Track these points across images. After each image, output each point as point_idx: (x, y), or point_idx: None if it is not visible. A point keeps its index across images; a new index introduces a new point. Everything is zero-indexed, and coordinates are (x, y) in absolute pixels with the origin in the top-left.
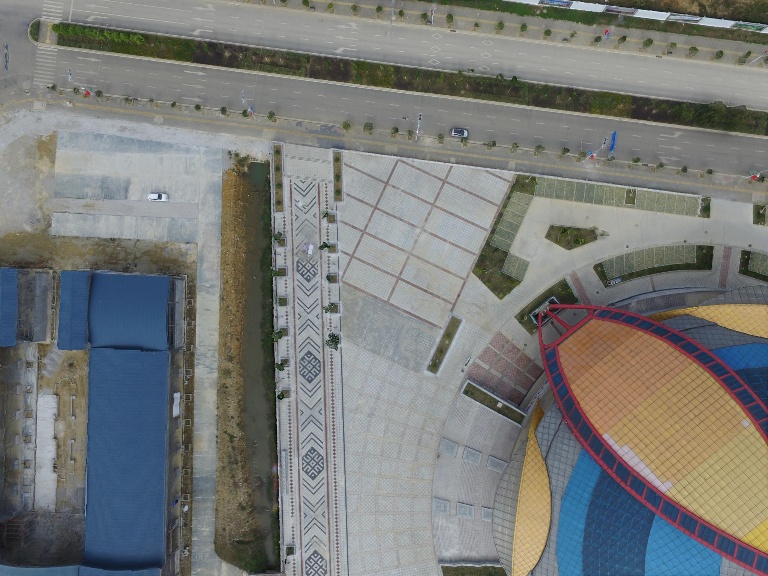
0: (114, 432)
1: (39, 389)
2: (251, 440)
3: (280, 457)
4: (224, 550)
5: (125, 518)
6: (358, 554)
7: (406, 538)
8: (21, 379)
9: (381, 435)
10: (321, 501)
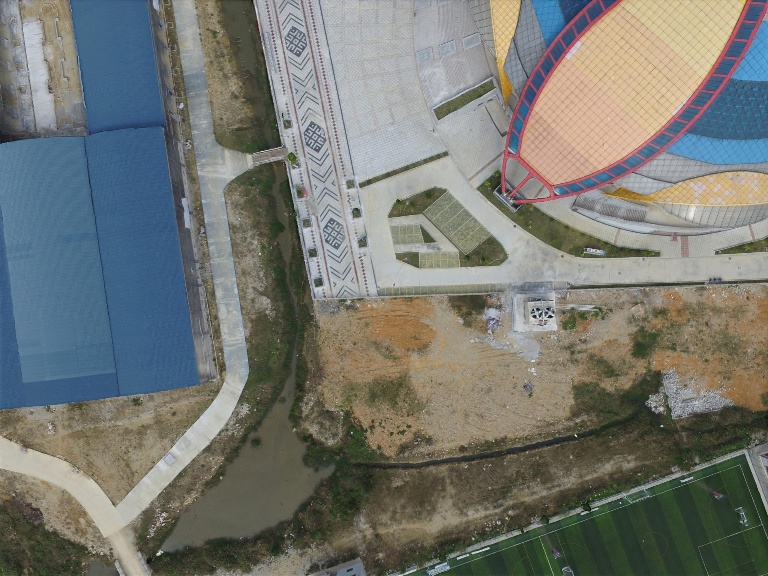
0: (98, 12)
1: (23, 19)
2: (234, 37)
3: (263, 40)
4: (224, 138)
5: (121, 89)
6: (353, 118)
7: (396, 96)
8: (4, 11)
9: (357, 4)
10: (309, 75)
